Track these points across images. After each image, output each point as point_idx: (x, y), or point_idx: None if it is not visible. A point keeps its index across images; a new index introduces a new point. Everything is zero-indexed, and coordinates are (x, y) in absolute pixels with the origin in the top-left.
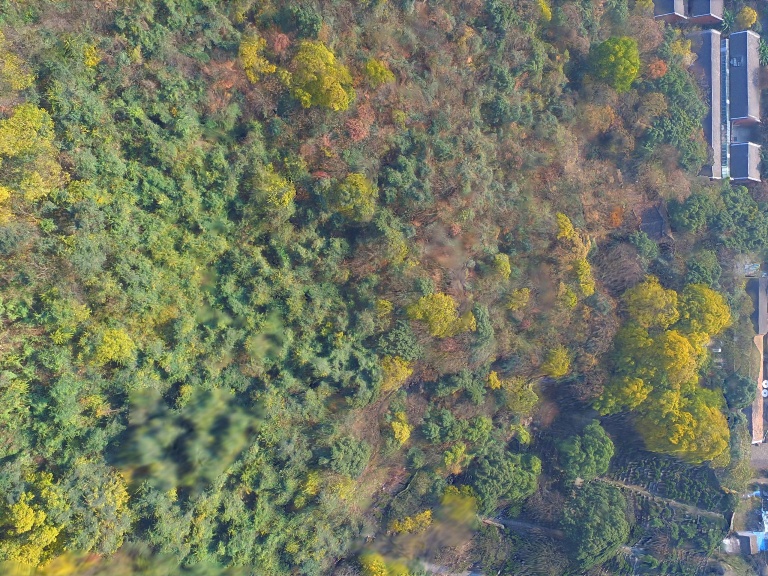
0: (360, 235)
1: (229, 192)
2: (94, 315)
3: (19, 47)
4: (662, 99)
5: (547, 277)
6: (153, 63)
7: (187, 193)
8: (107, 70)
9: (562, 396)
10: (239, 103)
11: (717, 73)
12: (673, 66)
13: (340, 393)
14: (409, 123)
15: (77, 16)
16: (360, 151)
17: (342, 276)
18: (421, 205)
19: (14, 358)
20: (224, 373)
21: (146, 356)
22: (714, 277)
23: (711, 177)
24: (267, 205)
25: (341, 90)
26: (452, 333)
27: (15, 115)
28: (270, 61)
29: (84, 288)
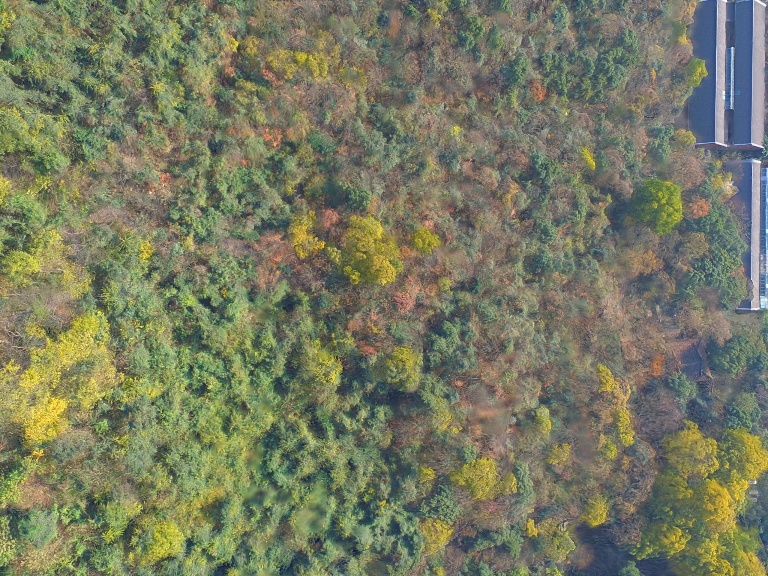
0: (404, 404)
1: (277, 372)
2: (145, 512)
3: (77, 251)
4: (704, 240)
5: (587, 429)
6: (205, 248)
7: (236, 376)
8: (160, 260)
9: (597, 536)
10: (287, 277)
11: (757, 202)
12: (714, 203)
13: (381, 561)
14: (454, 287)
15: (132, 208)
16: (406, 321)
17: (385, 440)
18: (465, 372)
19: (67, 562)
20: (269, 553)
21: (194, 544)
22: (753, 420)
23: (749, 309)
24: (314, 382)
25: (390, 268)
26: (493, 496)
27: (73, 327)
28: (319, 237)
29: (136, 487)
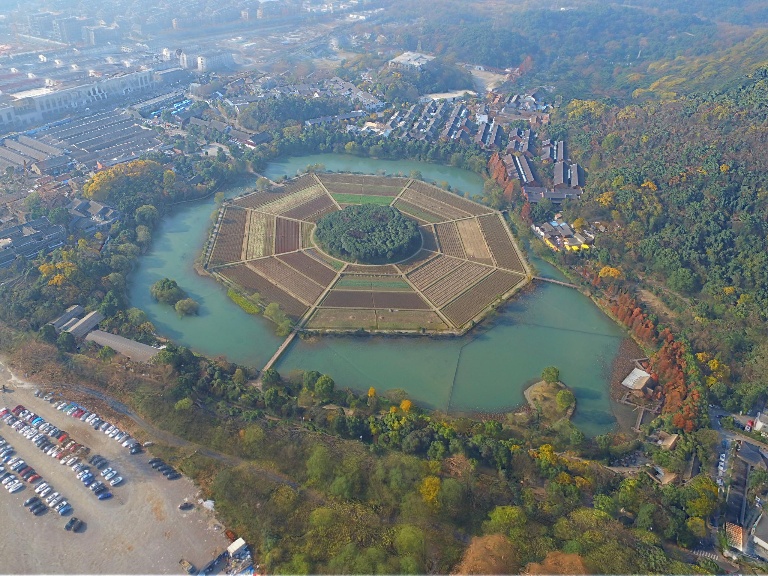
0: None
1: None
2: None
3: None
4: None
5: None
6: None
7: None
8: None
9: None
10: None
11: None
12: None
13: None
14: None
15: None
16: None
17: None
18: None
19: None
20: None
21: None
22: None
23: None
24: None
25: None
26: None
27: None
28: None
29: None
